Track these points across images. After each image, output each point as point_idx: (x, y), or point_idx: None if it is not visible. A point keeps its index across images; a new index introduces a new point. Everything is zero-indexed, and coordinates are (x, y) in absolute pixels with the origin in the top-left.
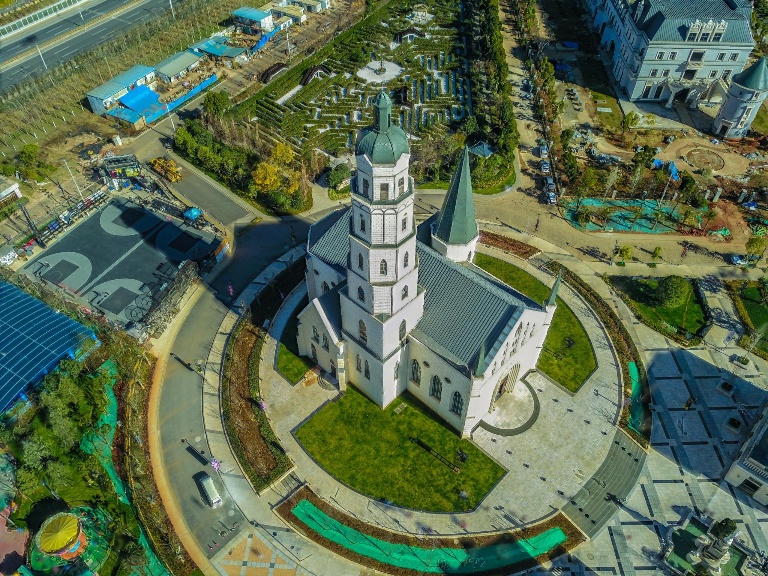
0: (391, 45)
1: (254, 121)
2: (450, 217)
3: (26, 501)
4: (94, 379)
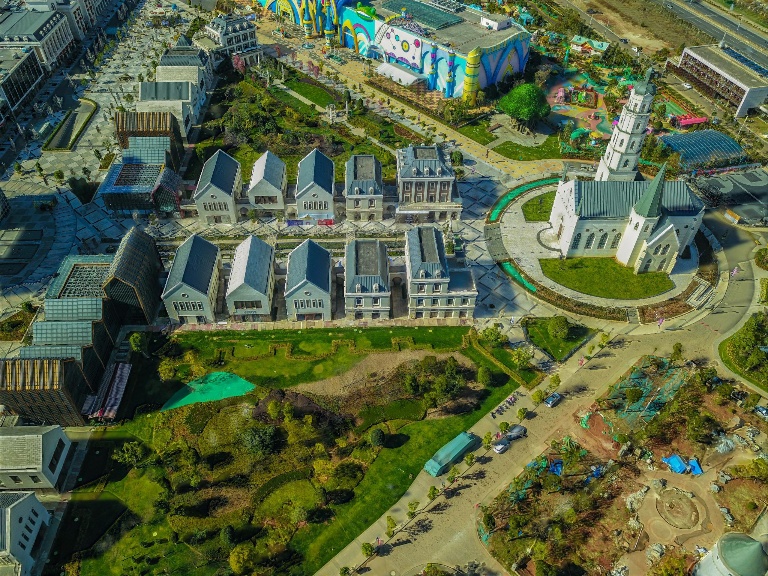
0: None
1: None
2: None
3: None
4: None
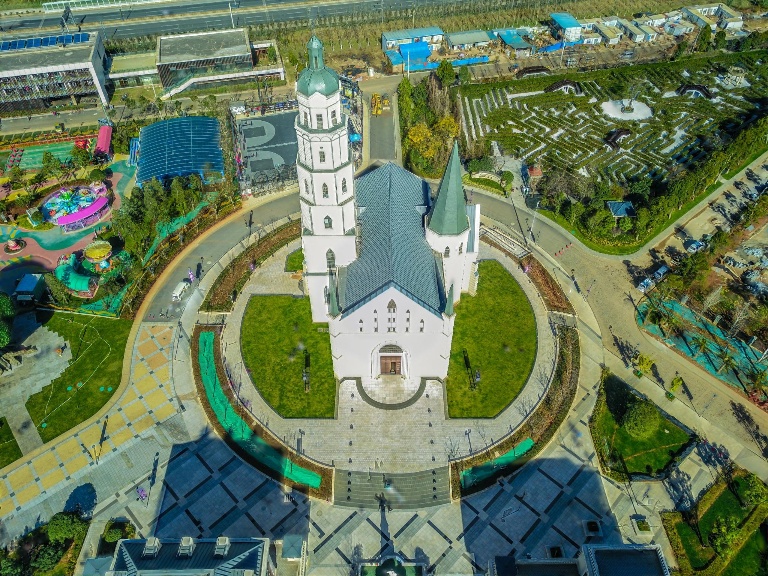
0: (669, 93)
1: (475, 101)
2: (435, 203)
3: (113, 232)
4: (200, 196)
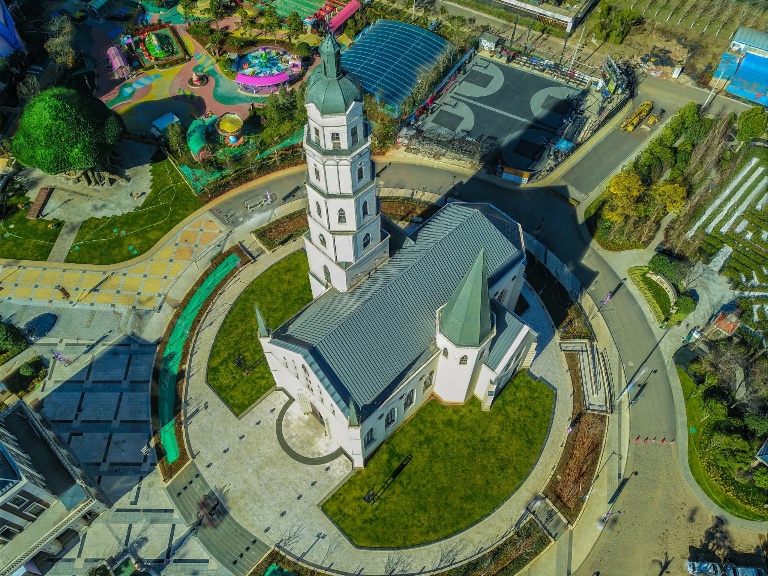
0: None
1: None
2: None
3: None
4: None
